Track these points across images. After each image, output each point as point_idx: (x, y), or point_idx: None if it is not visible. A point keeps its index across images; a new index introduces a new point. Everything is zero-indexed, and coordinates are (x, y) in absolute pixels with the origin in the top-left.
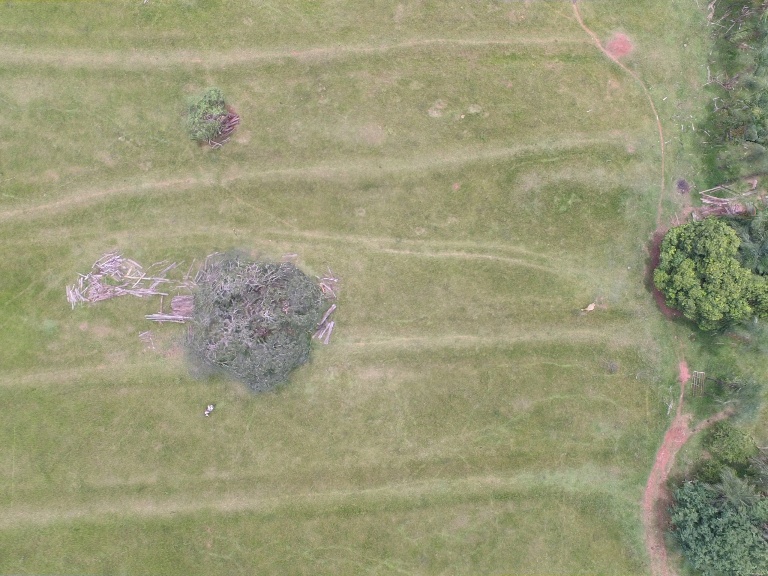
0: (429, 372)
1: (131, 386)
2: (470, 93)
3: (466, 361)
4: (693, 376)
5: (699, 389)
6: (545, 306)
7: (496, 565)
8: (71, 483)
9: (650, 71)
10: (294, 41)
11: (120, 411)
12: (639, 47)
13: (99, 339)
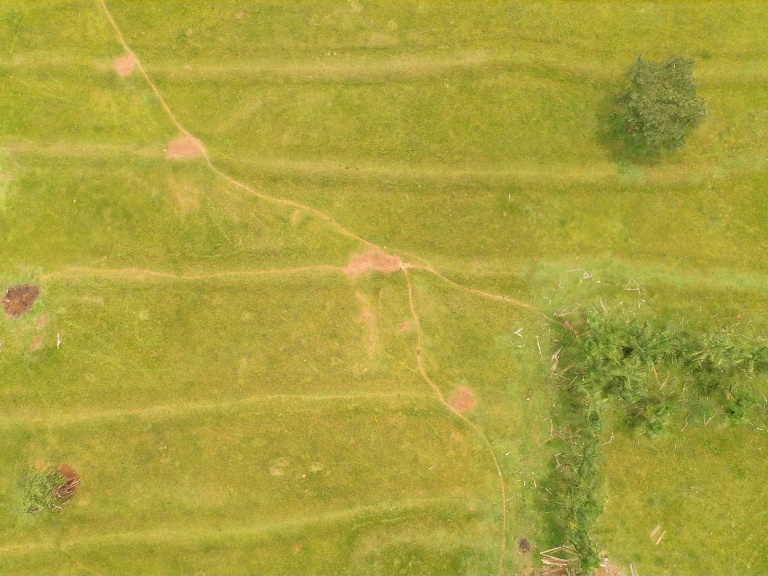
0: None
1: None
2: (312, 451)
3: None
4: None
5: None
6: None
7: None
8: None
9: (492, 427)
10: (136, 397)
11: None
12: (481, 403)
13: None
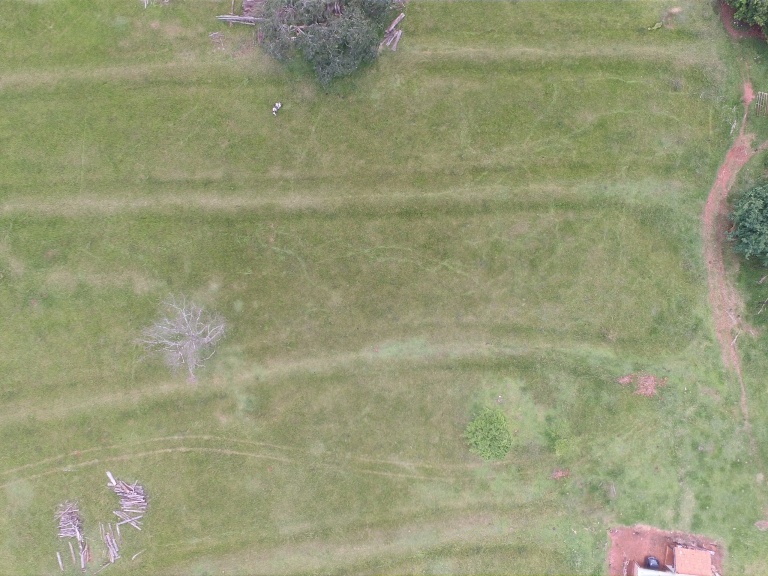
0: (494, 83)
1: (200, 85)
2: None
3: (531, 74)
4: (758, 96)
5: (763, 109)
6: (612, 23)
7: (554, 271)
8: (139, 174)
9: None
10: None
11: (189, 108)
12: None
13: (170, 37)
